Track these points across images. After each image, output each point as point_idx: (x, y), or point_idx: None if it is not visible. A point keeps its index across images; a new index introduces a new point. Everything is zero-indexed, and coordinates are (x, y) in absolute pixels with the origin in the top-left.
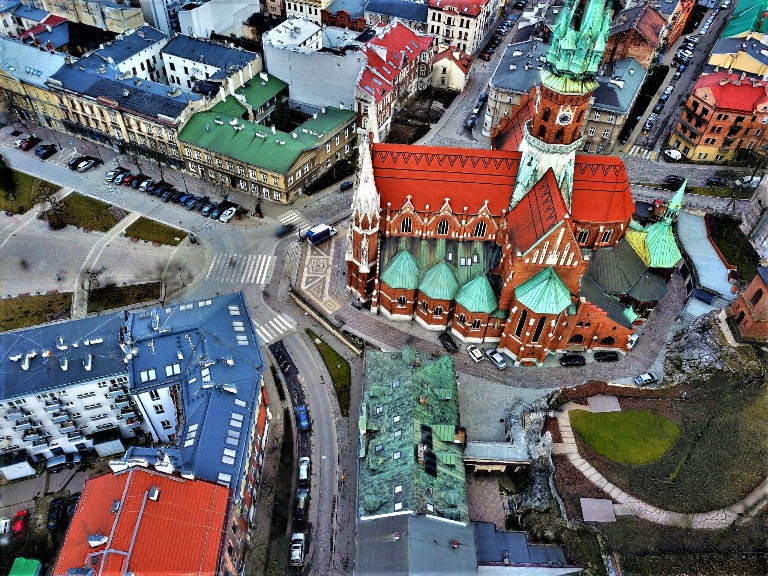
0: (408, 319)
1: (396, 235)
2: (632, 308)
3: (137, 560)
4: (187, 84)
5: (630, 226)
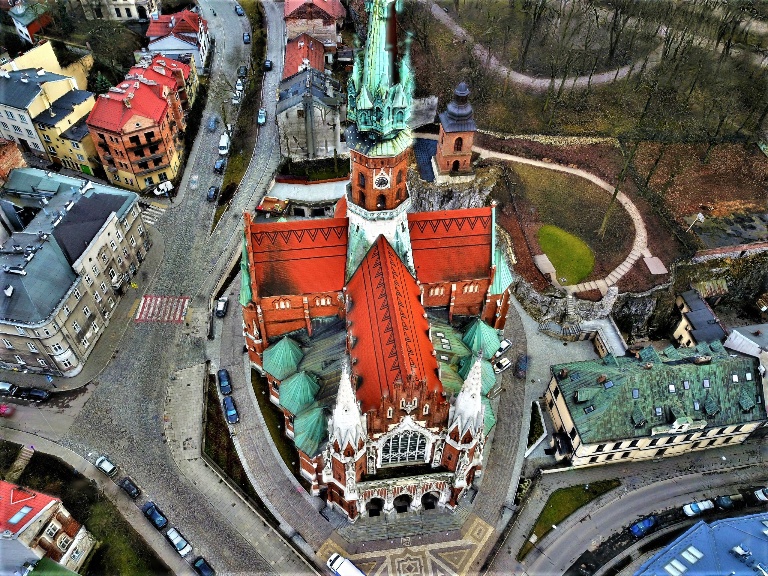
0: None
1: None
2: None
3: None
4: None
5: None
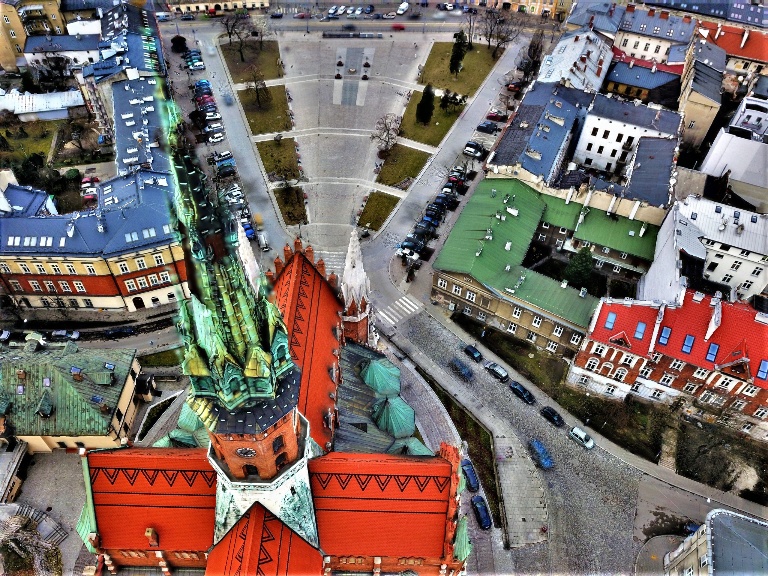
0: None
1: None
2: None
3: None
4: None
5: None
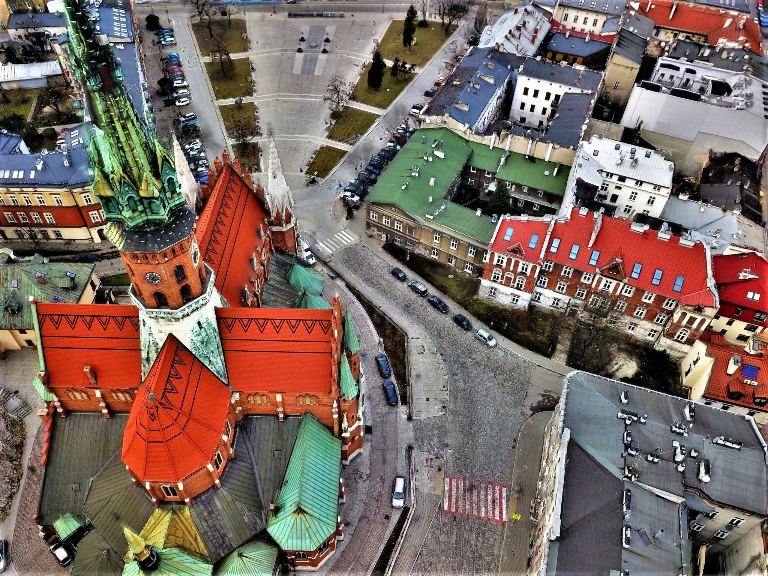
0: None
1: None
2: None
3: None
4: None
5: (229, 562)
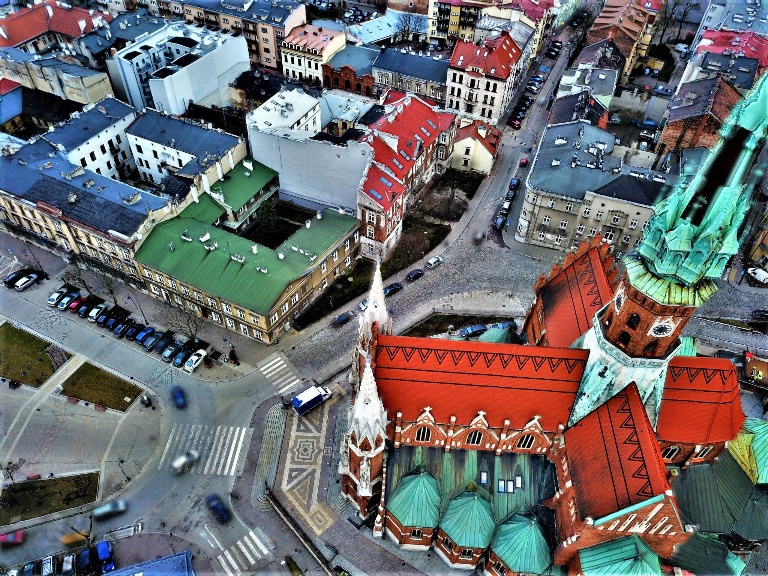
0: (424, 549)
1: (409, 444)
2: (733, 543)
3: None
4: (157, 169)
5: None
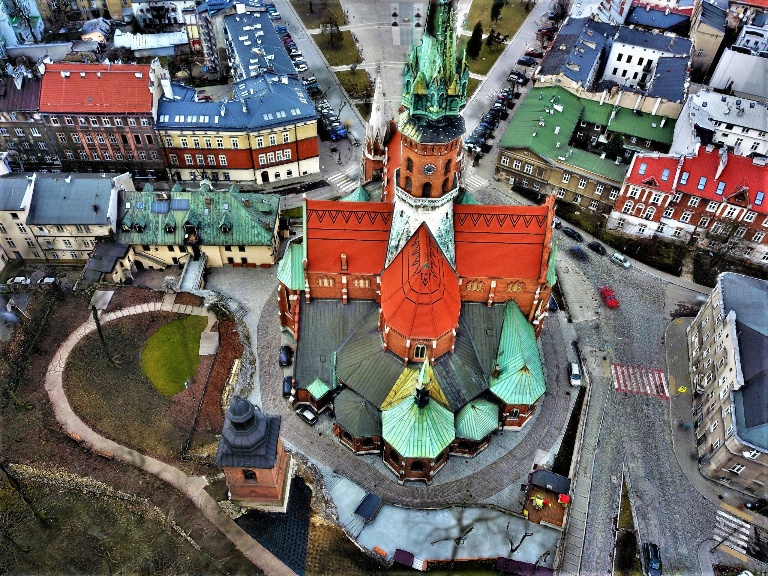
0: None
1: None
2: None
3: (107, 76)
4: None
5: (465, 412)
